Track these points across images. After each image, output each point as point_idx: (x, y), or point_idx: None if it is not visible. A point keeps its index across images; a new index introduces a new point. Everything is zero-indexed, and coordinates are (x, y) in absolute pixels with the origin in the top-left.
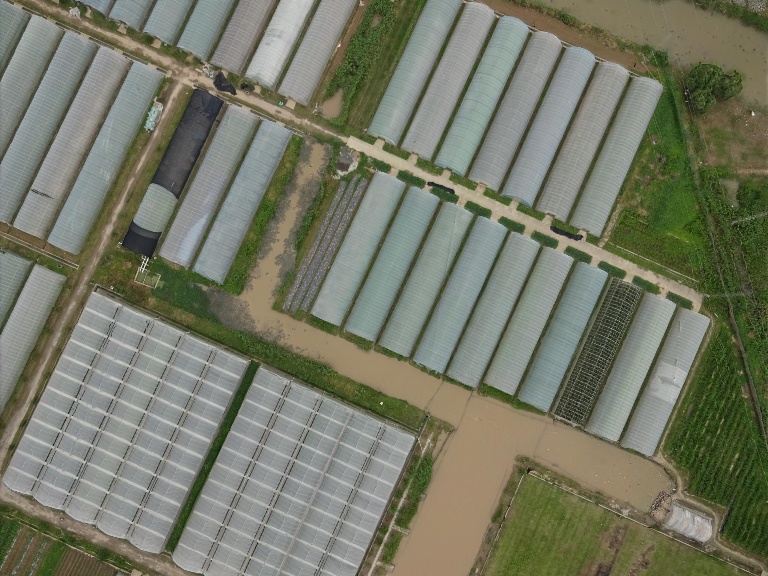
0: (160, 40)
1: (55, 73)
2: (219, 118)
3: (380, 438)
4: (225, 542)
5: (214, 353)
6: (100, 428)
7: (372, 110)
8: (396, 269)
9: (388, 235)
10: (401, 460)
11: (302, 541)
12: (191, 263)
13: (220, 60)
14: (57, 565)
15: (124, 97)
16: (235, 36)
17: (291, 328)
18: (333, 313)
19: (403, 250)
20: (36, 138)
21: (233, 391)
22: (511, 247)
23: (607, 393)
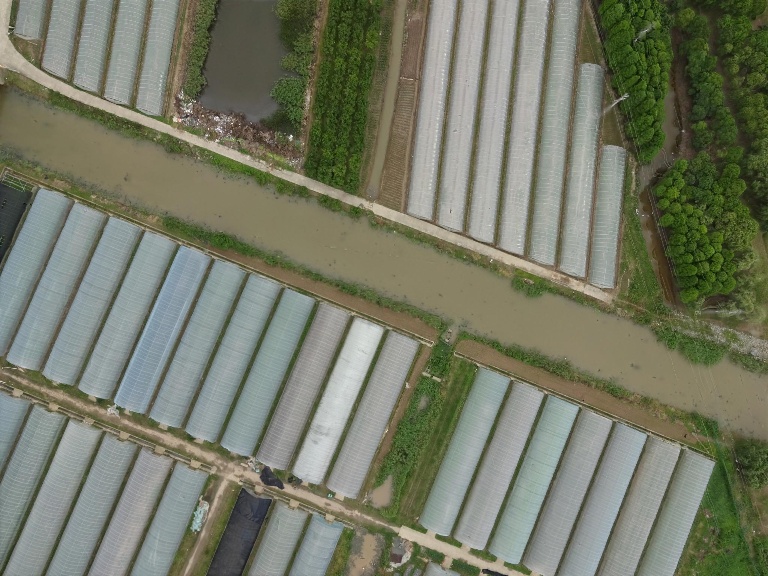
0: None
1: (97, 485)
2: (267, 515)
3: None
4: None
5: None
6: None
7: (423, 497)
8: None
9: None
10: None
11: None
12: None
13: (267, 462)
14: None
15: (170, 507)
16: (281, 436)
17: None
18: None
19: None
20: (80, 553)
21: None
22: None
23: None
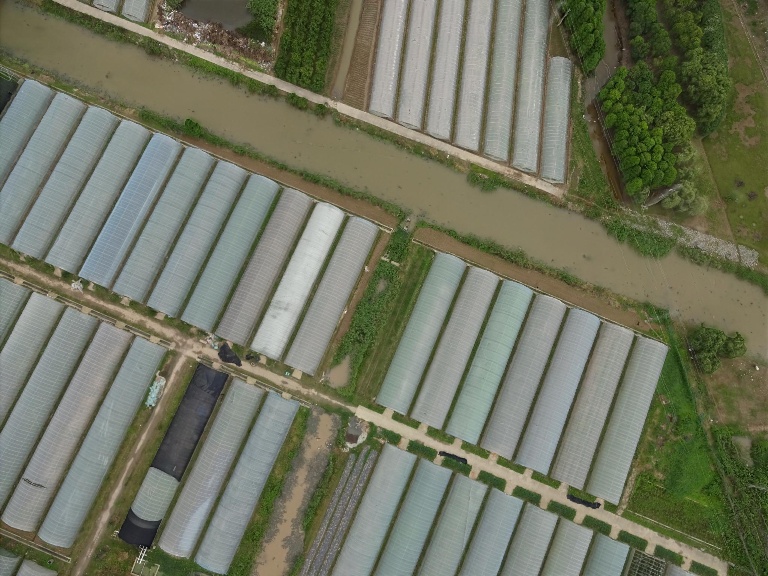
0: (164, 313)
1: (54, 353)
2: (224, 391)
3: None
4: None
5: None
6: None
7: (380, 377)
8: (410, 553)
9: (401, 513)
10: None
11: None
12: (192, 551)
13: (225, 335)
14: None
15: (126, 376)
16: (241, 310)
17: None
18: None
19: (417, 531)
20: (31, 422)
21: None
22: (529, 522)
23: None
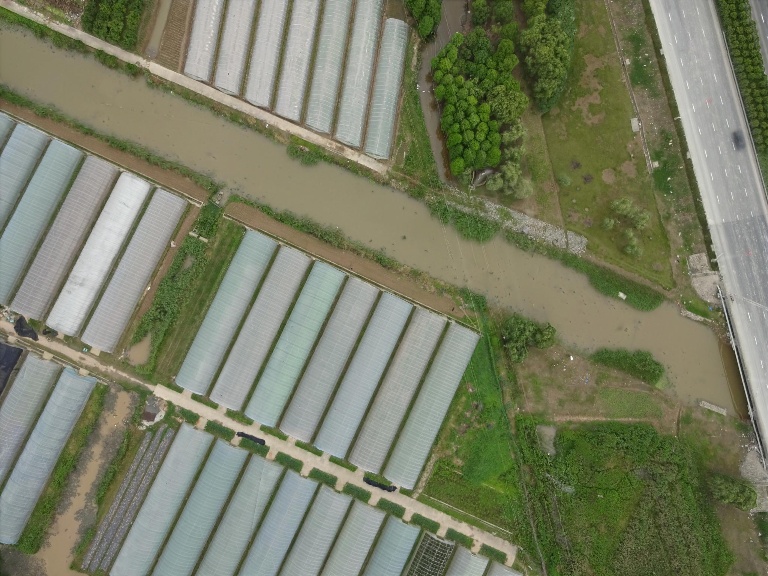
0: None
1: None
2: (19, 366)
3: None
4: None
5: None
6: None
7: (181, 356)
8: (198, 530)
9: (193, 491)
10: None
11: None
12: None
13: (18, 309)
14: None
15: None
16: (34, 284)
17: None
18: None
19: (206, 510)
20: None
21: None
22: (319, 504)
23: None
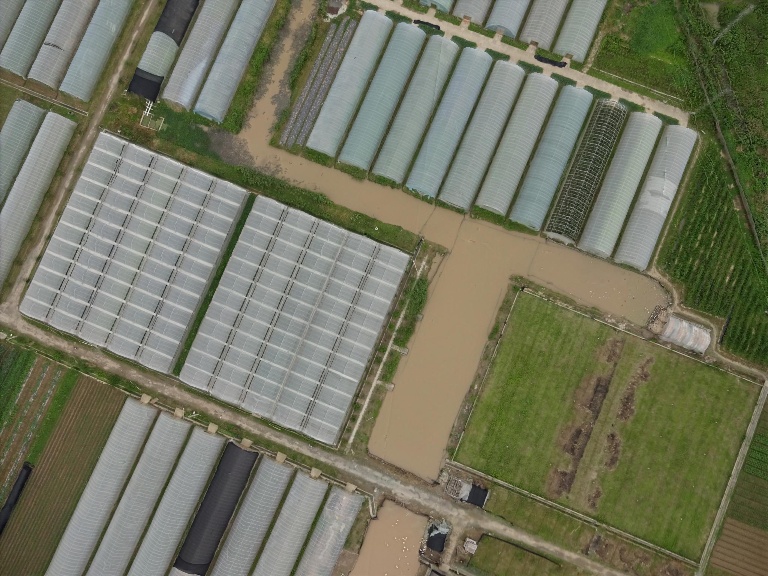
0: None
1: None
2: None
3: (375, 257)
4: (229, 360)
5: (215, 183)
6: (109, 257)
7: None
8: (386, 98)
9: (377, 69)
10: (396, 276)
11: (303, 358)
12: (192, 105)
13: None
14: (71, 391)
15: None
16: None
17: (288, 162)
18: (327, 142)
19: (392, 80)
20: None
21: (234, 218)
22: (496, 74)
23: (597, 208)
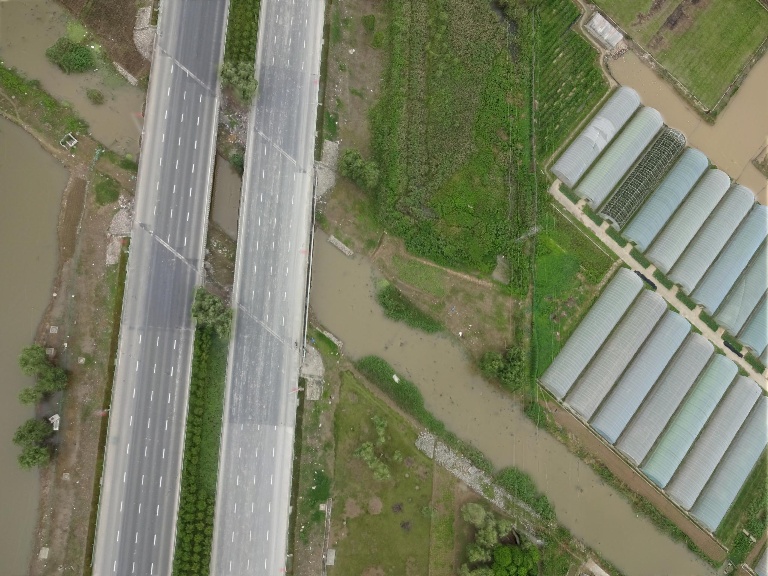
0: None
1: None
2: None
3: None
4: None
5: None
6: None
7: None
8: None
9: None
10: None
11: None
12: None
13: None
14: None
15: None
16: None
17: None
18: None
19: None
20: None
21: None
22: None
23: None
